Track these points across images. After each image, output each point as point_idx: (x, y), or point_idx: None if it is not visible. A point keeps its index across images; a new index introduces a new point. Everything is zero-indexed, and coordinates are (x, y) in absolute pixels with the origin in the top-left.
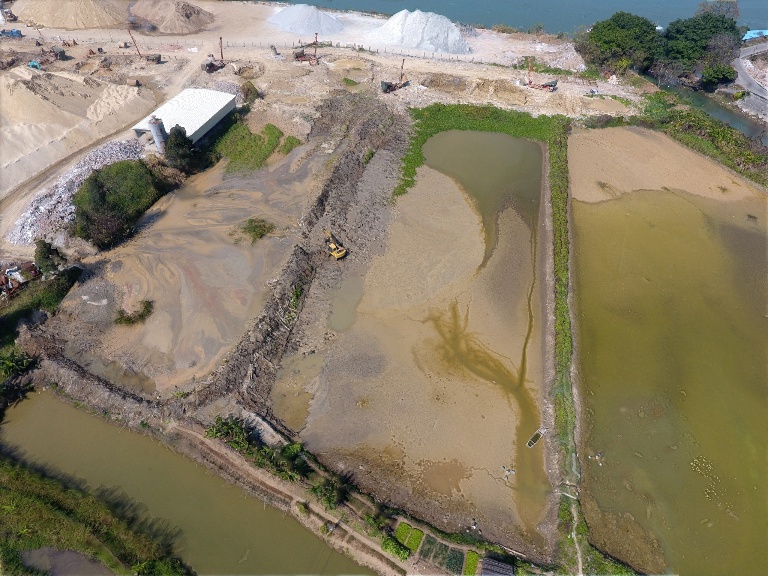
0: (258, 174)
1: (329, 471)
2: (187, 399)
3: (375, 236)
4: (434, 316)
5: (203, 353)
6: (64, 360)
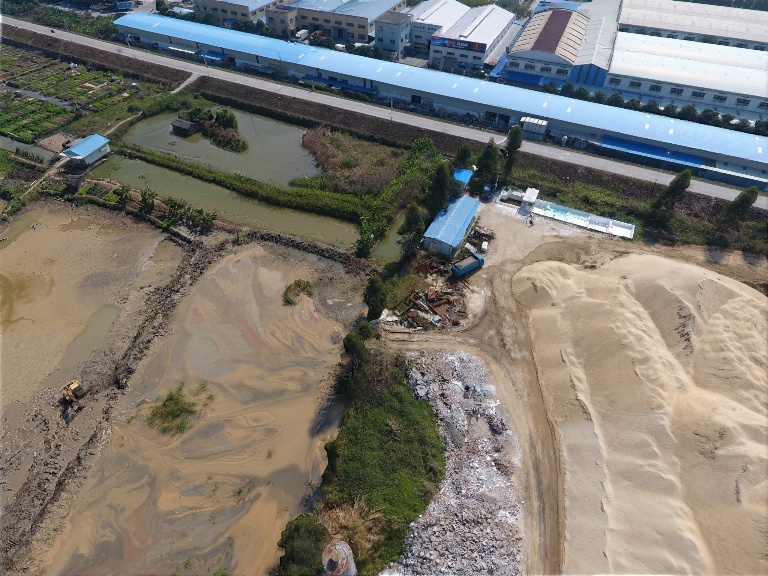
0: (160, 575)
1: (148, 219)
2: (235, 236)
3: (4, 439)
4: (5, 325)
5: (230, 268)
6: (337, 258)
